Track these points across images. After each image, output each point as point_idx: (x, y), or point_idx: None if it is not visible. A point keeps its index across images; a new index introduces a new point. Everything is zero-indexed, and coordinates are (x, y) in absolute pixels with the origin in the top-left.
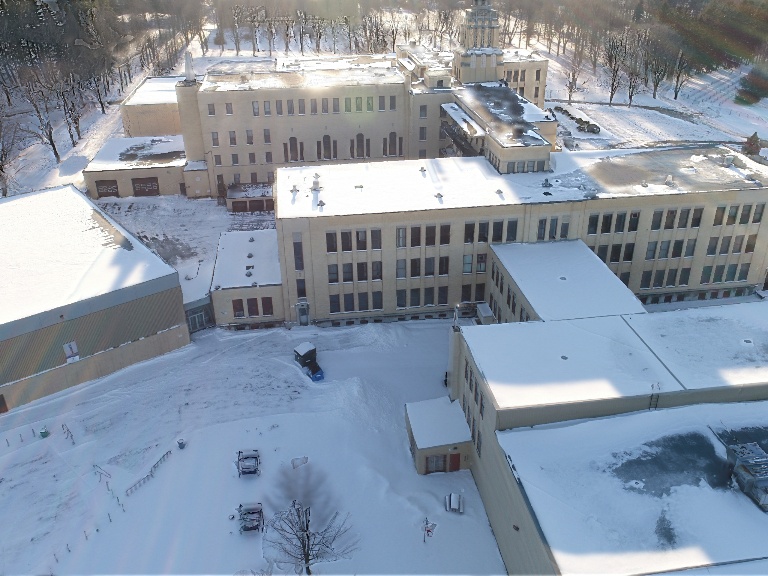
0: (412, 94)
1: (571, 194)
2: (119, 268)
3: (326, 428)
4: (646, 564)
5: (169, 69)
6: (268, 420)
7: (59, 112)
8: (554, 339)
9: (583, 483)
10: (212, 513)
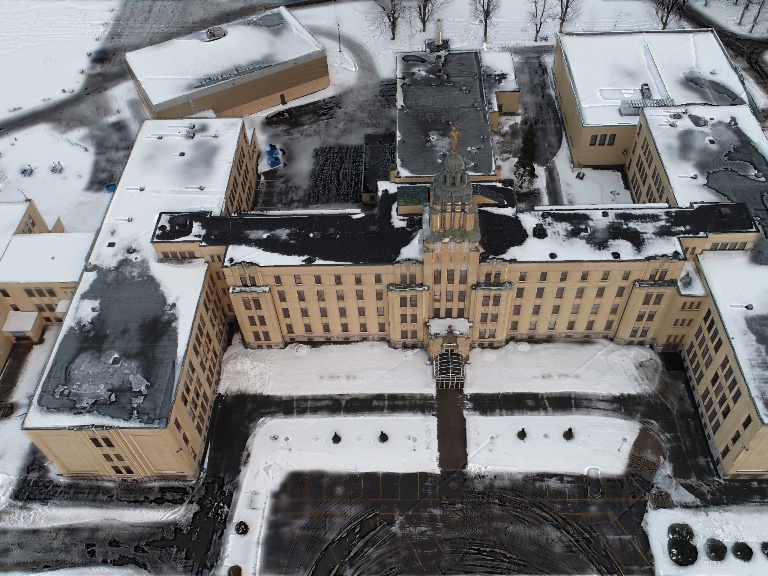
0: None
1: (106, 259)
2: (172, 87)
3: (71, 194)
4: None
5: None
6: (87, 174)
7: (648, 9)
8: None
9: None
10: (41, 162)
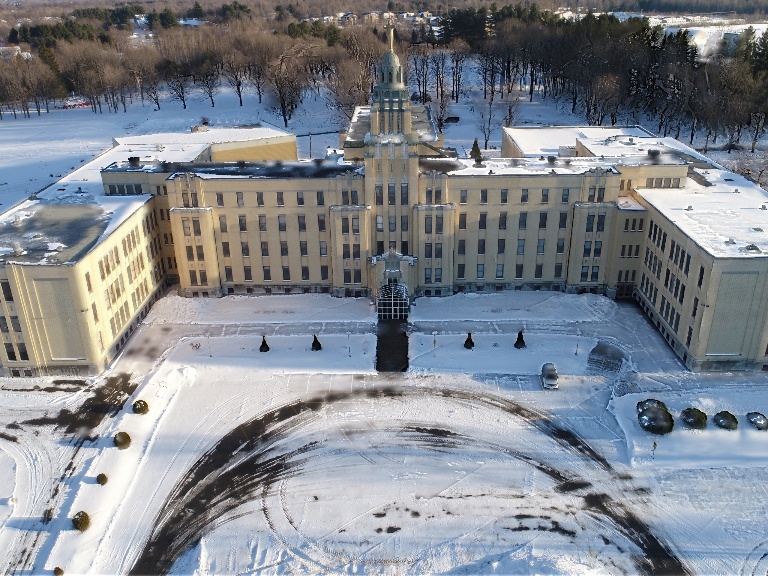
0: None
1: (52, 195)
2: None
3: None
4: None
5: (759, 137)
6: None
7: None
8: None
9: None
10: None
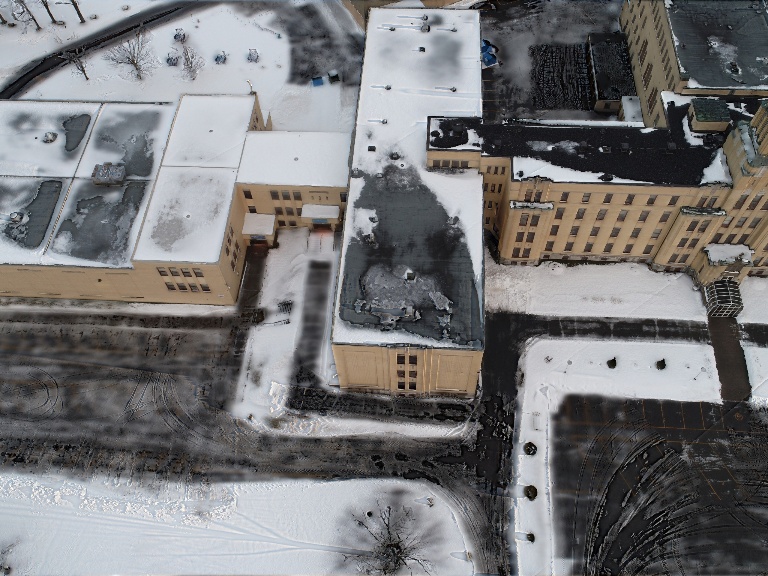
0: None
1: (370, 164)
2: None
3: (274, 86)
4: (98, 127)
5: None
6: (286, 65)
7: None
8: (229, 131)
9: (143, 123)
10: None
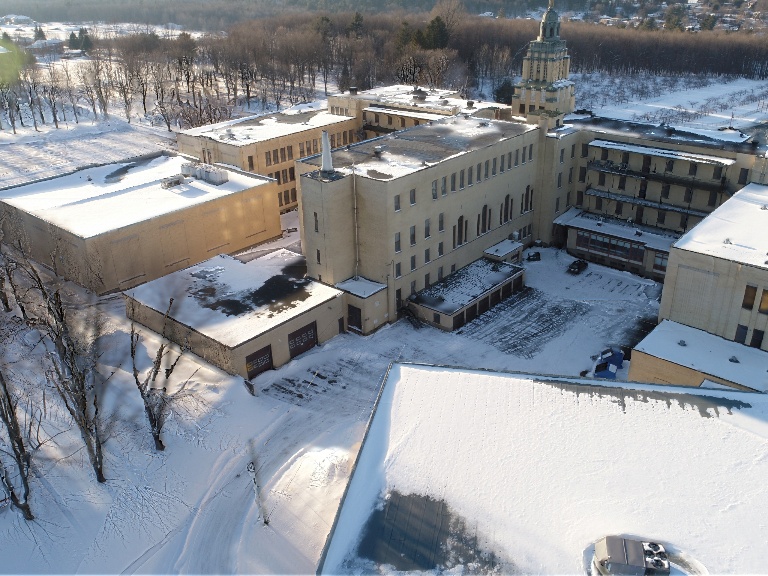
0: (559, 138)
1: None
2: None
3: None
4: None
5: None
6: None
7: None
8: None
9: None
10: None
